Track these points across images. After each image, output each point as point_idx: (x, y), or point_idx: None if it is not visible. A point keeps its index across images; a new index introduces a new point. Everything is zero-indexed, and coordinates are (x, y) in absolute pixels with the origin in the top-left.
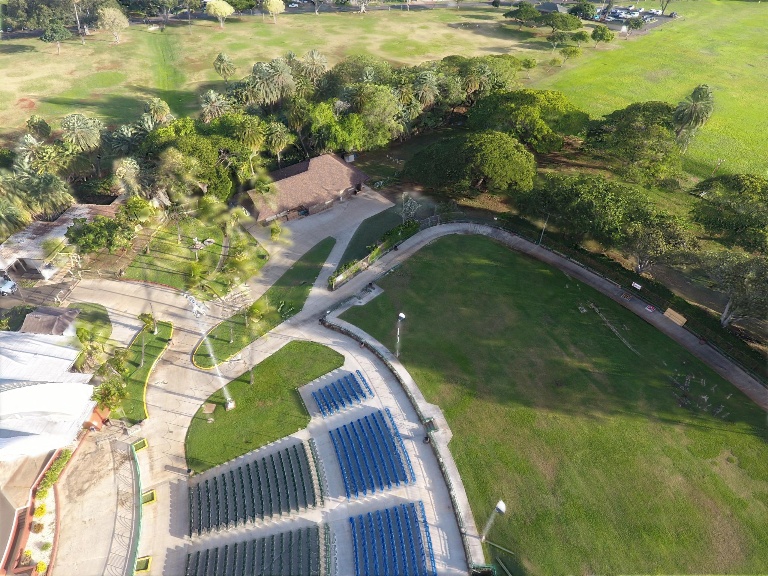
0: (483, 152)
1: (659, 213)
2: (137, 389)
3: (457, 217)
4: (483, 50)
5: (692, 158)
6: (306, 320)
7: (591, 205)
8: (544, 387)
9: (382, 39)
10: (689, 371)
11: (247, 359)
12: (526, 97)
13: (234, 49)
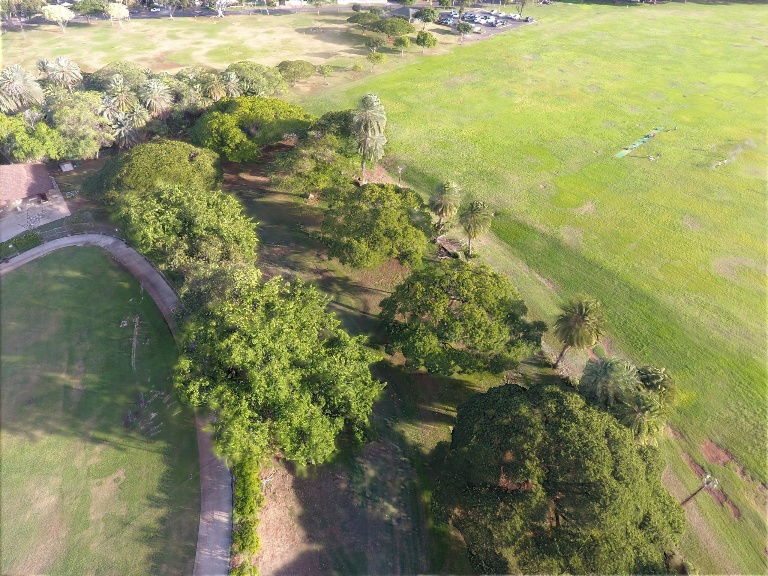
0: (132, 162)
1: (209, 226)
2: None
3: (86, 228)
4: (307, 55)
5: (414, 165)
6: None
7: (131, 218)
8: (14, 405)
9: (216, 44)
10: (164, 387)
11: None
12: (234, 105)
13: (56, 54)
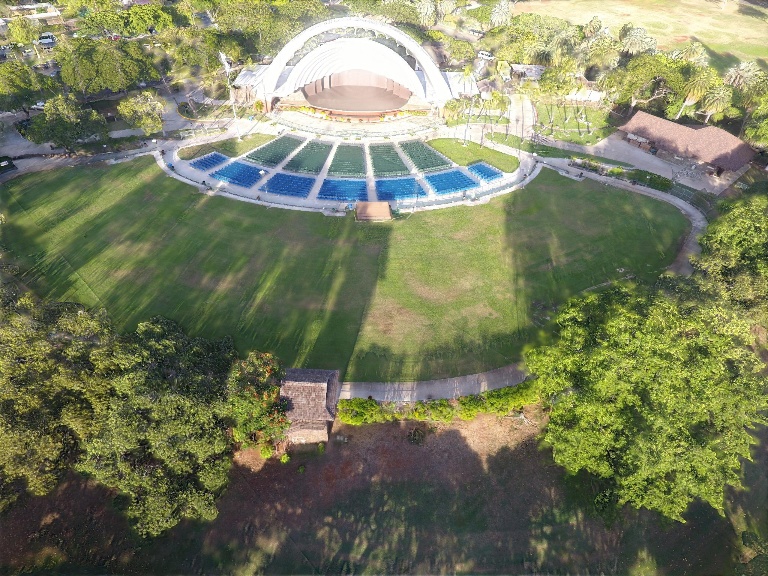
0: None
1: None
2: (464, 122)
3: (704, 207)
4: None
5: None
6: (536, 159)
7: None
8: (522, 241)
9: None
10: None
11: (497, 147)
12: None
13: None
